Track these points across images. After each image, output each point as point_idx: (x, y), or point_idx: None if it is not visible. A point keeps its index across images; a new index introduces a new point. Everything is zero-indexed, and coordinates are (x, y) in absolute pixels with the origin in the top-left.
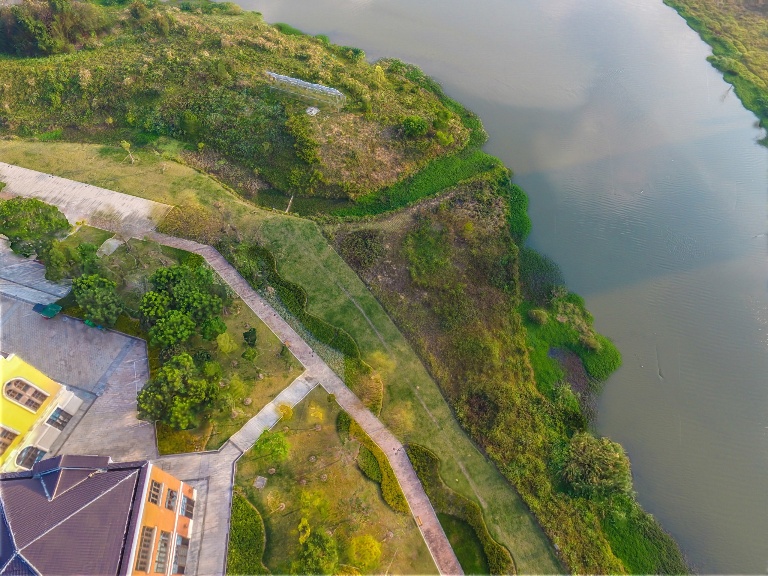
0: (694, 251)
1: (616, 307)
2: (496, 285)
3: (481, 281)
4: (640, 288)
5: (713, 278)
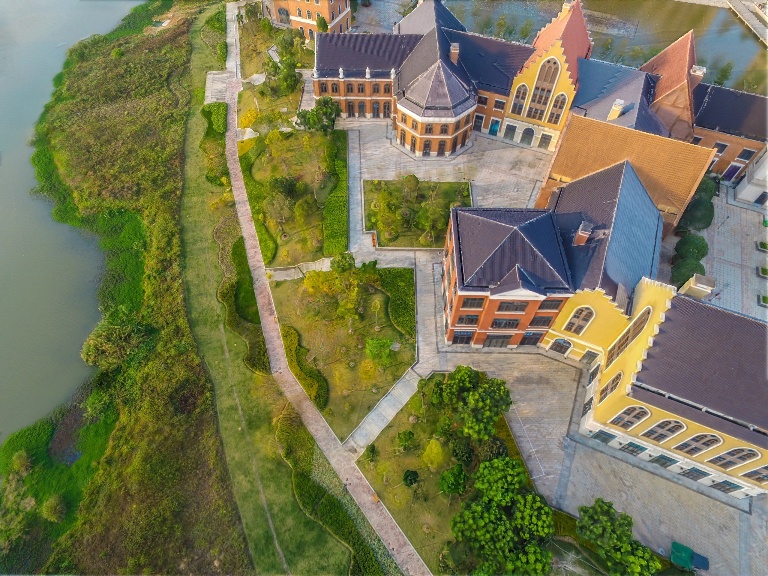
0: None
1: None
2: (77, 571)
3: None
4: None
5: None
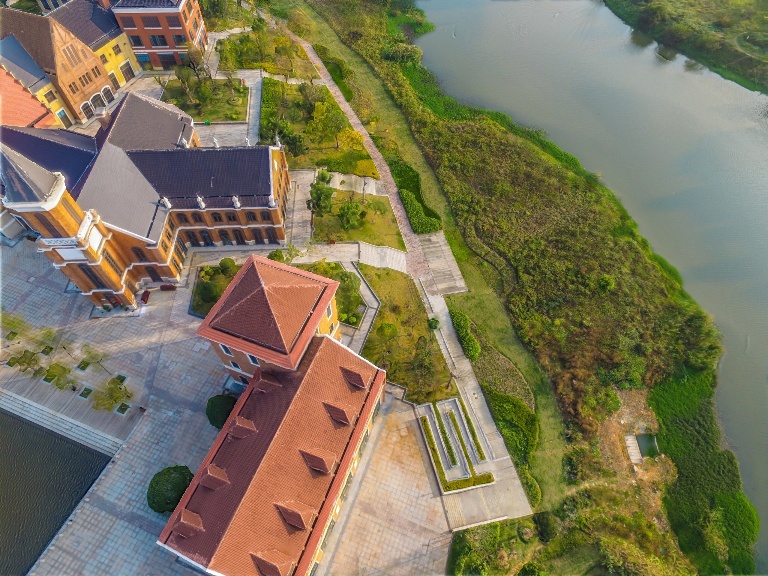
0: (527, 37)
1: (441, 14)
2: (377, 3)
3: (369, 2)
4: (458, 9)
5: (530, 43)
